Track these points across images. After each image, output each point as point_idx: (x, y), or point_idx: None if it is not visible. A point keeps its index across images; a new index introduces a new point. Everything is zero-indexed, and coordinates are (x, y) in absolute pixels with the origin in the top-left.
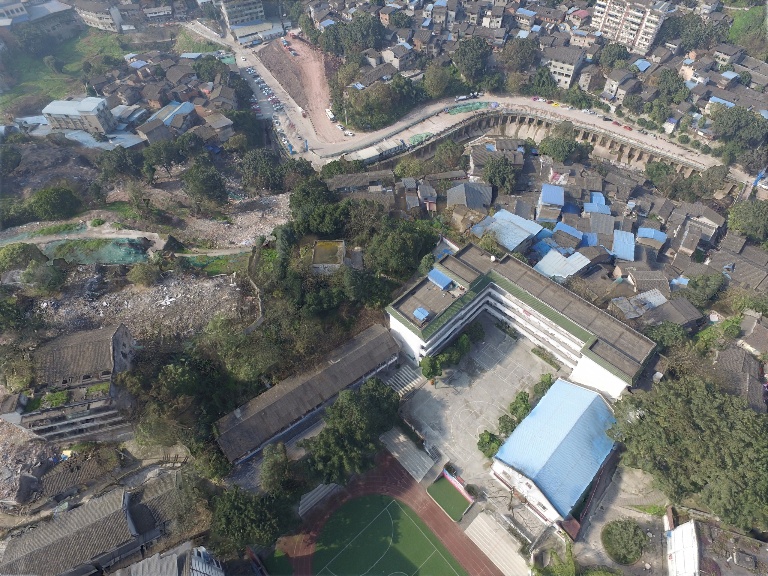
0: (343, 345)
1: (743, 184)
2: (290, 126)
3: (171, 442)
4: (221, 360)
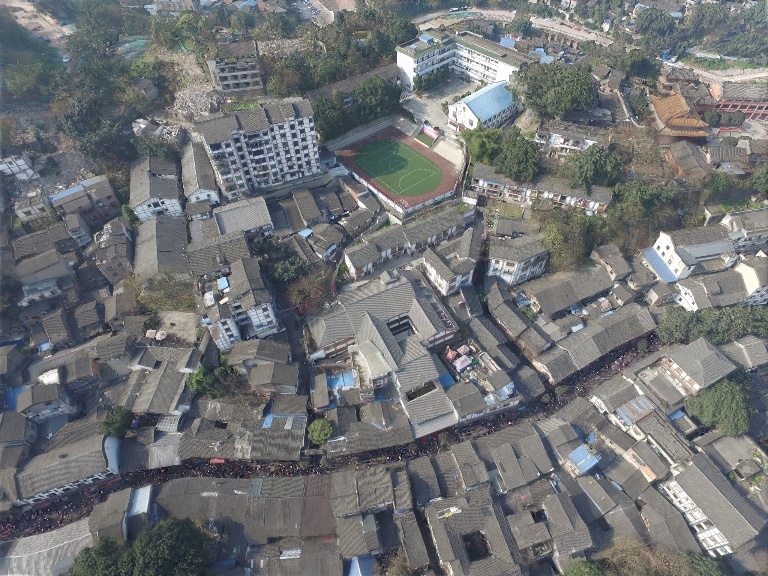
0: None
1: None
2: (325, 23)
3: (283, 95)
4: (305, 70)
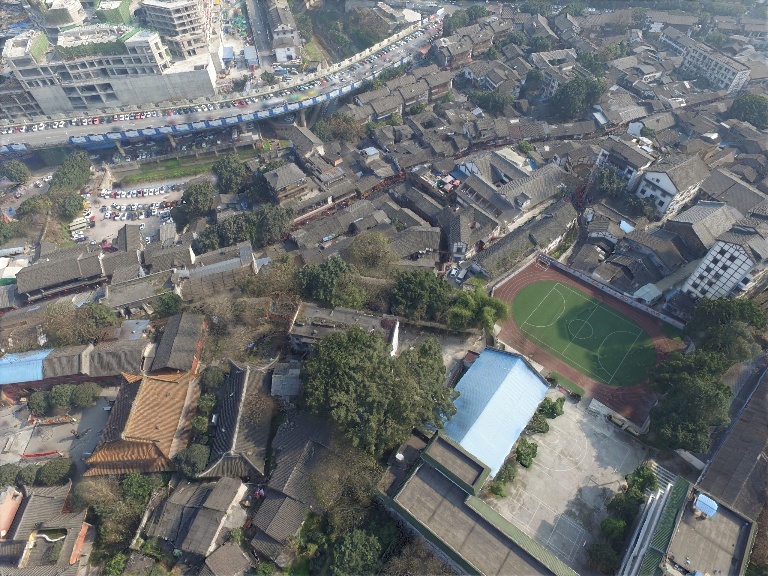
0: (767, 492)
1: None
2: None
3: None
4: None
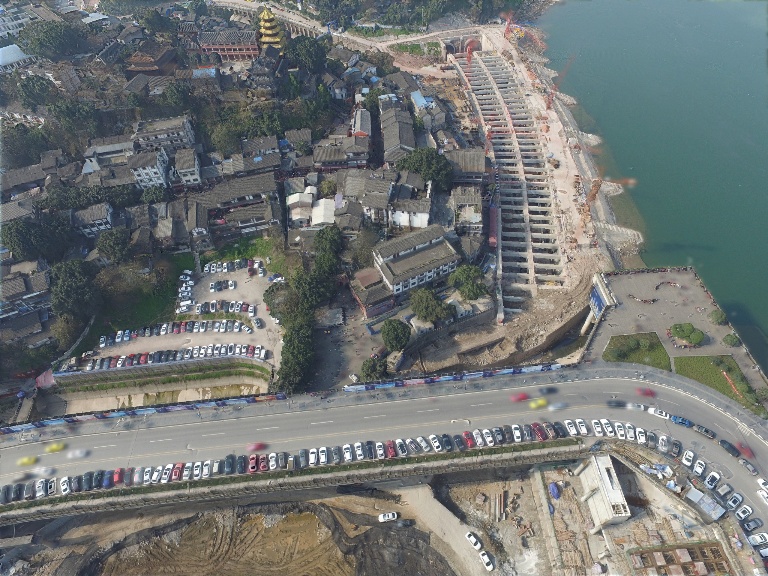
0: None
1: (323, 33)
2: None
3: None
4: None
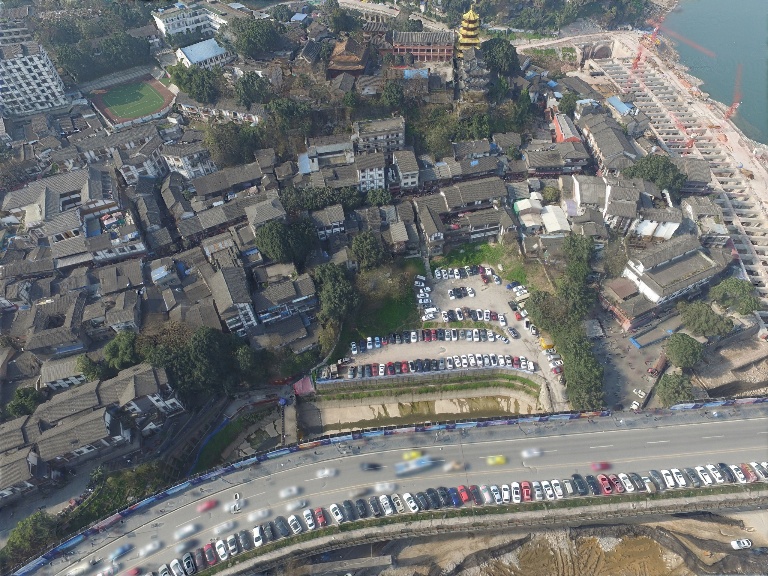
0: None
1: None
2: None
3: (50, 48)
4: (78, 31)
